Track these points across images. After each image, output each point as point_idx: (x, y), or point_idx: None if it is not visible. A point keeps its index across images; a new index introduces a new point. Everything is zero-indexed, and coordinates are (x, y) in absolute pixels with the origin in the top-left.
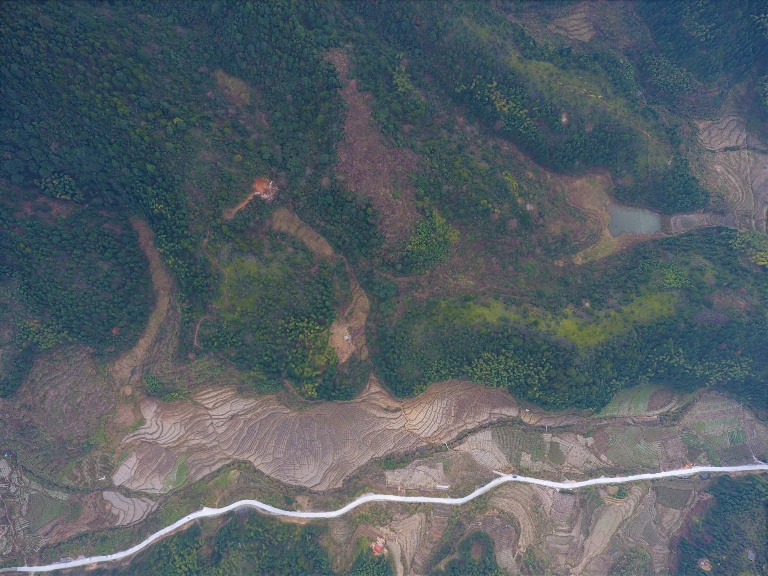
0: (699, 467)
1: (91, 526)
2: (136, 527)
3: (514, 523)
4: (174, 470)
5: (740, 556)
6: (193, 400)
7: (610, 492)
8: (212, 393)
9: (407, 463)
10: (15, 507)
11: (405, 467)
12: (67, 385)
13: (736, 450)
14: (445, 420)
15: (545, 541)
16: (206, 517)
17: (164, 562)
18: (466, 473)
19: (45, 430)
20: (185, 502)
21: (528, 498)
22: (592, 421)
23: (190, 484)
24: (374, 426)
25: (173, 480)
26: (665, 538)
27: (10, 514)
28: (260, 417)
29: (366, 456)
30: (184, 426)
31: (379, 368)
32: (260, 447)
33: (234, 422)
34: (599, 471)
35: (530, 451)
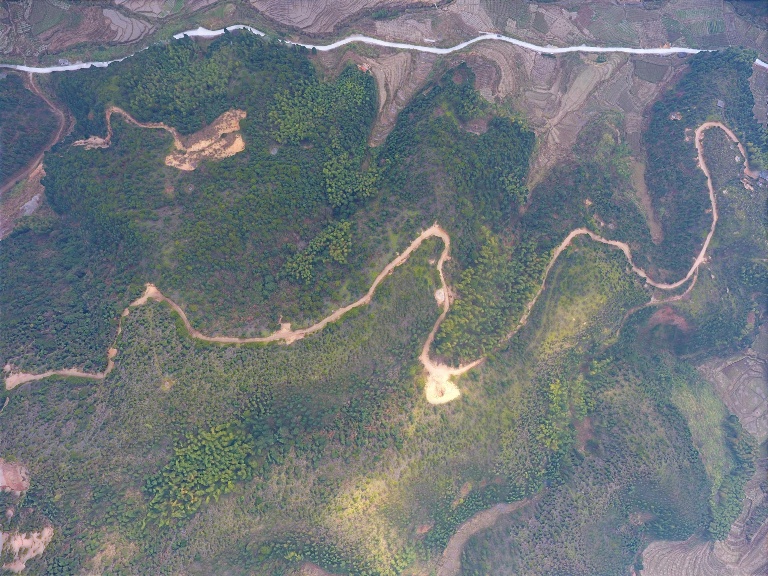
0: (677, 48)
1: (90, 38)
2: (133, 45)
3: (495, 65)
4: None
5: (710, 103)
6: None
7: (590, 59)
8: None
9: (397, 16)
10: (18, 11)
11: (395, 19)
12: None
13: (714, 38)
14: None
15: (524, 95)
16: (201, 37)
17: (158, 52)
18: (453, 31)
19: None
20: (181, 23)
21: (511, 53)
22: None
23: (187, 13)
24: None
25: (171, 6)
26: (640, 107)
27: (13, 17)
28: None
29: (358, 5)
30: None
31: None
32: None
33: None
34: (581, 40)
35: (516, 17)
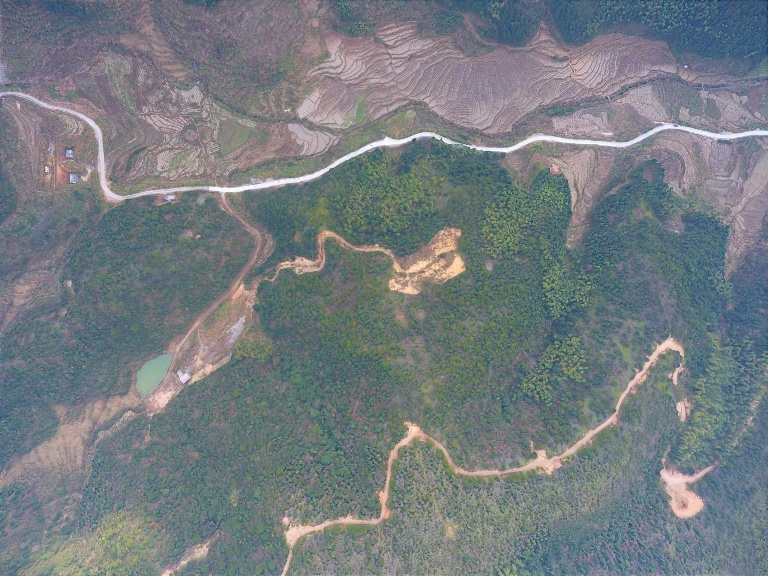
0: None
1: (277, 154)
2: (319, 157)
3: (680, 158)
4: (354, 107)
5: None
6: (375, 36)
7: (765, 143)
8: (394, 29)
9: (573, 111)
10: (206, 132)
11: (571, 115)
12: (262, 8)
13: None
14: (608, 73)
15: (705, 184)
16: (387, 146)
17: (357, 169)
18: (628, 122)
19: (242, 48)
20: (367, 133)
21: (689, 143)
22: (745, 82)
23: (369, 122)
24: (542, 75)
25: (353, 116)
26: None
27: (202, 138)
28: (435, 61)
29: (534, 103)
30: (365, 64)
31: (555, 5)
32: (435, 90)
33: (411, 64)
34: (754, 124)
35: (688, 105)
